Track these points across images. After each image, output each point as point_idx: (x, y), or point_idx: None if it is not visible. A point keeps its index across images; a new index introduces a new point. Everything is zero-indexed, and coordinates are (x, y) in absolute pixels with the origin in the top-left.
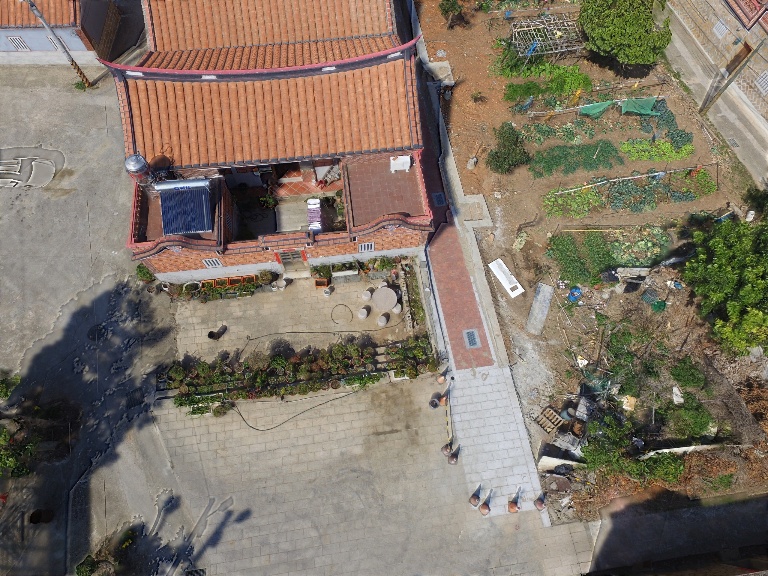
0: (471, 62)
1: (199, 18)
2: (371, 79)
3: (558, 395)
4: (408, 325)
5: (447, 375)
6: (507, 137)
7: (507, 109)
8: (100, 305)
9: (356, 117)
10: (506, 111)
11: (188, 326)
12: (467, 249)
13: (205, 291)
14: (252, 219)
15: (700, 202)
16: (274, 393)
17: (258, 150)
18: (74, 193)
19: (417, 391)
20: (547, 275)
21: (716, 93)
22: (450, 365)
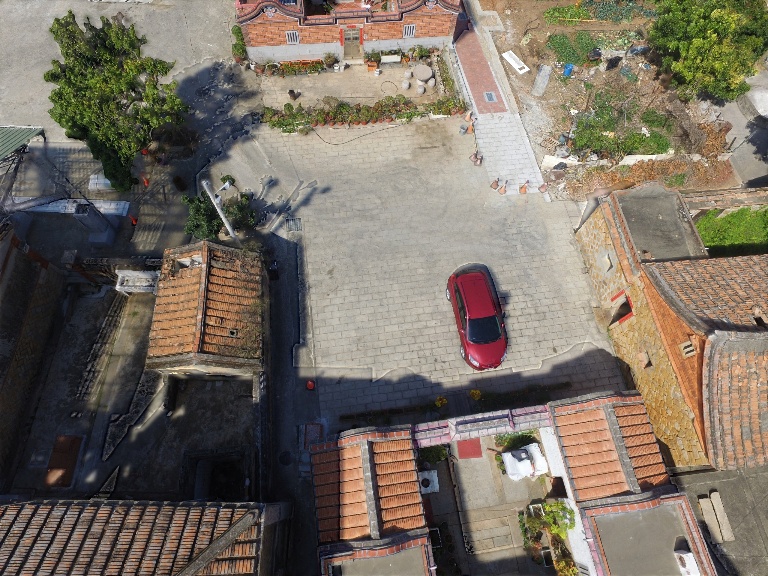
0: None
1: None
2: None
3: (556, 132)
4: (441, 90)
5: (472, 116)
6: None
7: None
8: (202, 76)
9: None
10: None
11: (271, 92)
12: (485, 45)
13: (283, 68)
14: None
15: None
16: (343, 121)
17: None
18: (173, 8)
19: (450, 125)
20: (547, 60)
21: None
22: (474, 111)
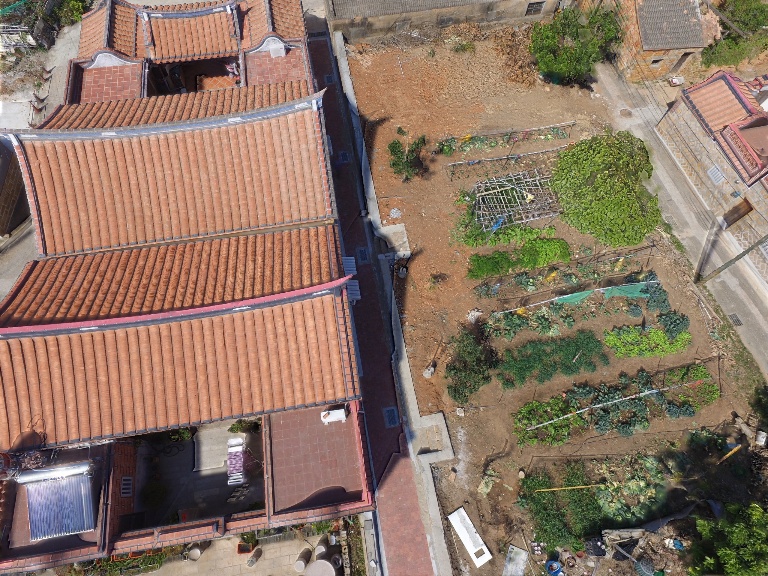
0: (430, 225)
1: (98, 209)
2: (294, 316)
3: None
4: None
5: None
6: (468, 352)
7: (471, 290)
8: None
9: (277, 364)
10: (470, 293)
11: None
12: (423, 493)
13: (100, 568)
14: (165, 453)
15: (700, 414)
16: None
17: (154, 415)
18: None
19: None
20: (519, 533)
21: (713, 250)
22: None
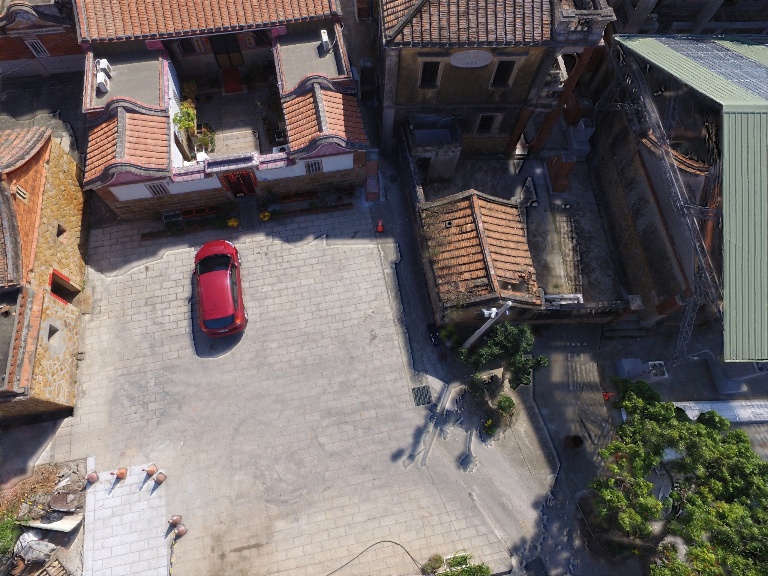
0: None
1: None
2: None
3: None
4: None
5: None
6: None
7: None
8: None
9: None
10: None
11: None
12: None
13: None
14: None
15: None
16: None
17: None
18: None
19: None
20: None
21: None
22: None
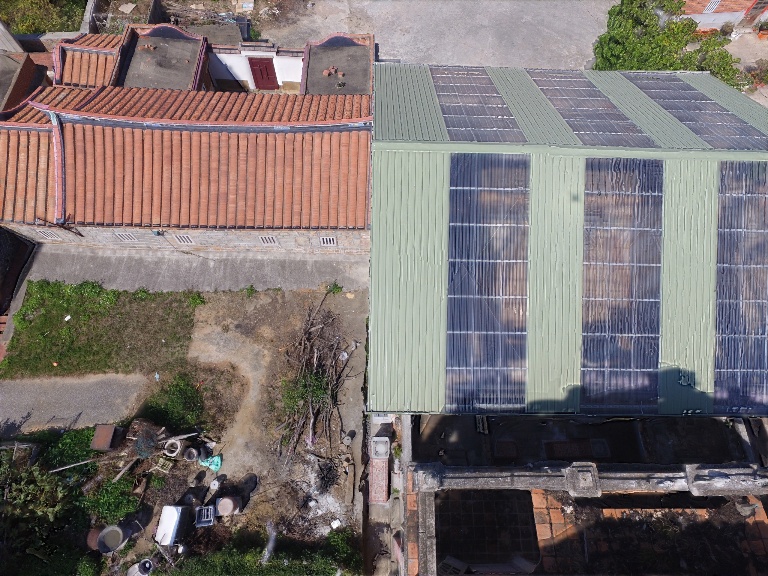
0: None
1: None
2: None
3: None
4: None
5: None
6: None
7: None
8: None
9: None
10: None
11: None
12: None
13: None
14: None
15: None
16: None
17: None
18: None
19: None
20: None
21: None
22: None
